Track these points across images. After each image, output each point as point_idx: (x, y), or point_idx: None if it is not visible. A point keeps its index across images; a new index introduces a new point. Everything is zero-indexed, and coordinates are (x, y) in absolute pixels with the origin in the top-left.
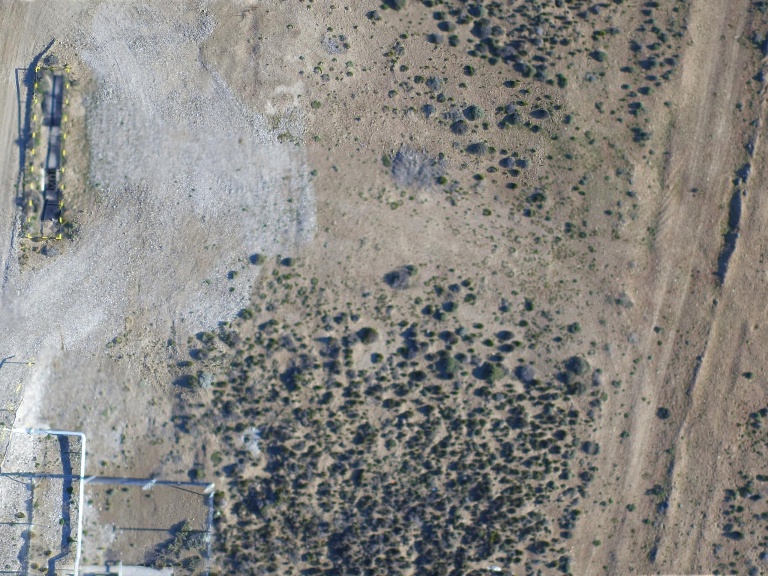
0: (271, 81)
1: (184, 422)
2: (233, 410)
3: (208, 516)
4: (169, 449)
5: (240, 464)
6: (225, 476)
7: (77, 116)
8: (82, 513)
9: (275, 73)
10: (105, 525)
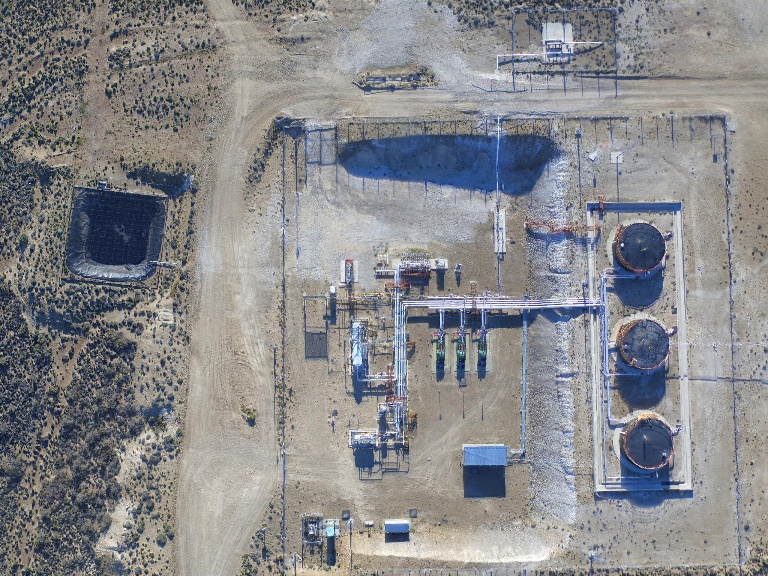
0: (362, 4)
1: (491, 23)
2: (485, 7)
3: (524, 12)
4: (501, 28)
5: (504, 3)
6: (509, 8)
7: (381, 72)
8: (526, 54)
9: (359, 3)
10: (529, 48)
